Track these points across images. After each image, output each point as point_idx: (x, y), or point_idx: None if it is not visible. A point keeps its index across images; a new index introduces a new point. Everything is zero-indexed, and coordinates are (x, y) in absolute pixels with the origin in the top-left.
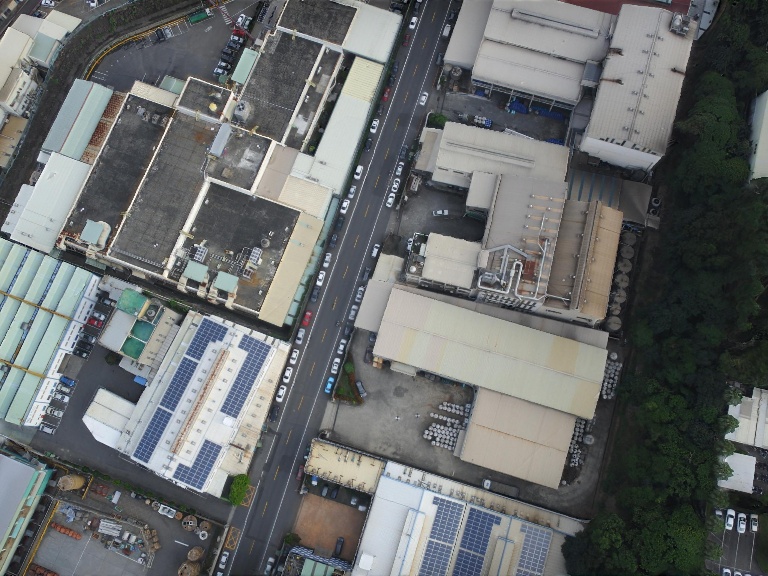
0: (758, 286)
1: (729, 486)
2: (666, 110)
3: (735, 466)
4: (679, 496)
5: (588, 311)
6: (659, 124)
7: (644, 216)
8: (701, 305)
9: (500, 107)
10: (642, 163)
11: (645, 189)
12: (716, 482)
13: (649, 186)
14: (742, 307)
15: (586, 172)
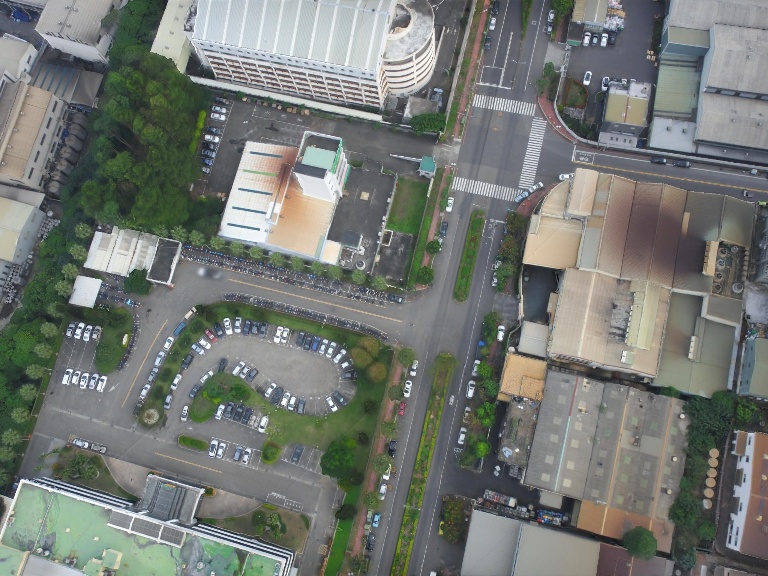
0: (99, 138)
1: (77, 303)
2: (99, 8)
3: (85, 287)
4: (33, 310)
5: (6, 171)
6: (91, 19)
7: (92, 99)
8: (93, 163)
9: (8, 17)
10: (96, 56)
11: (96, 77)
12: (63, 299)
13: (100, 75)
14: (94, 157)
15: (52, 65)
